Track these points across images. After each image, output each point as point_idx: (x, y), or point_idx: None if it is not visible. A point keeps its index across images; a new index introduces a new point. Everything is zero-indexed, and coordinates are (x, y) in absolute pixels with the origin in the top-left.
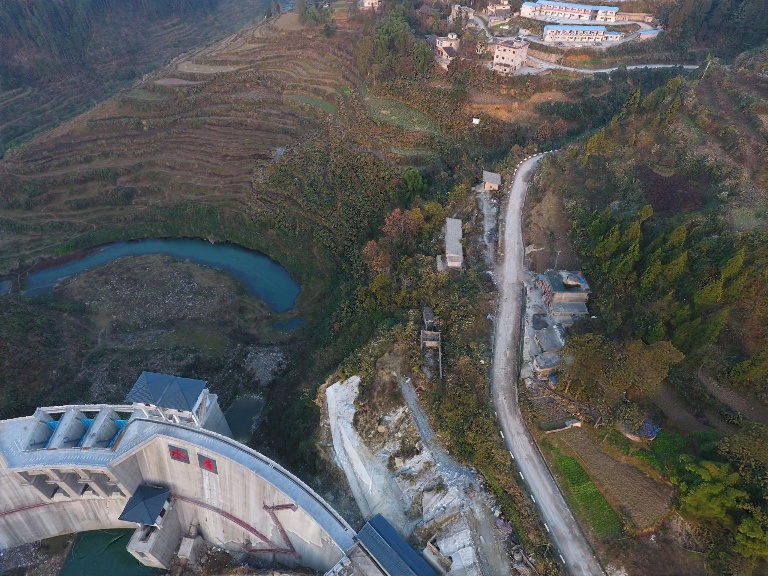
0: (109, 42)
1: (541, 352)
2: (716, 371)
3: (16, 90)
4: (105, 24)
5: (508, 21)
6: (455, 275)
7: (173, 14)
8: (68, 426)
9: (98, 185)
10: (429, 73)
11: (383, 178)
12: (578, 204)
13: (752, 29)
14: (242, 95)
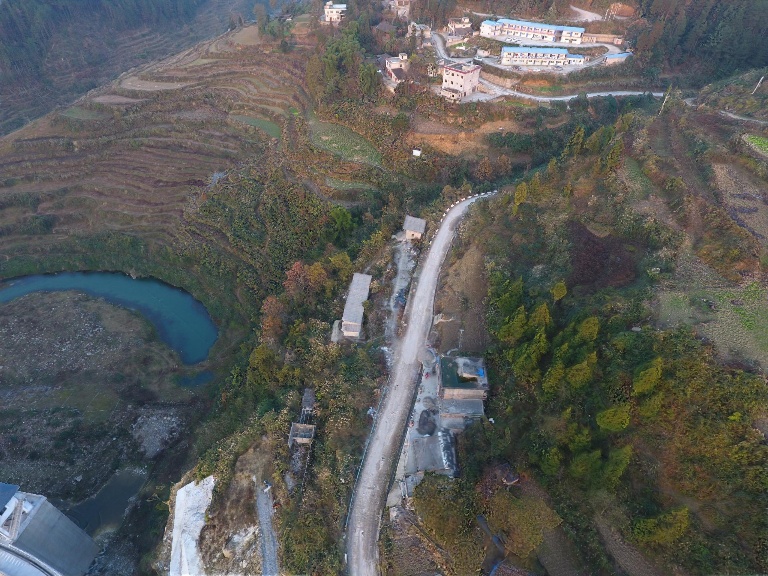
0: (70, 53)
1: (417, 469)
2: (619, 521)
3: None
4: (67, 34)
5: (467, 41)
6: (349, 348)
7: (145, 24)
8: None
9: (17, 211)
10: (376, 96)
11: (313, 214)
12: (498, 266)
13: (729, 54)
14: (185, 114)
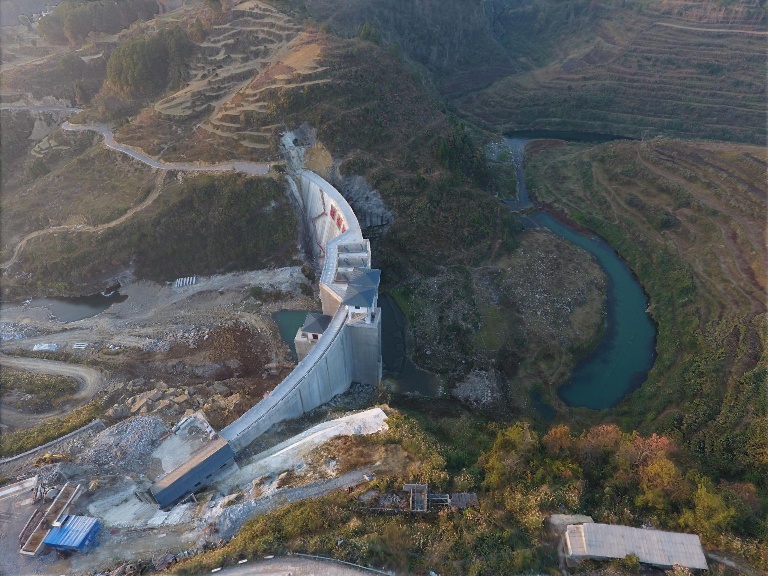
0: None
1: None
2: None
3: None
4: None
5: None
6: (544, 542)
7: None
8: (355, 257)
9: (666, 200)
10: None
11: None
12: None
13: None
14: None
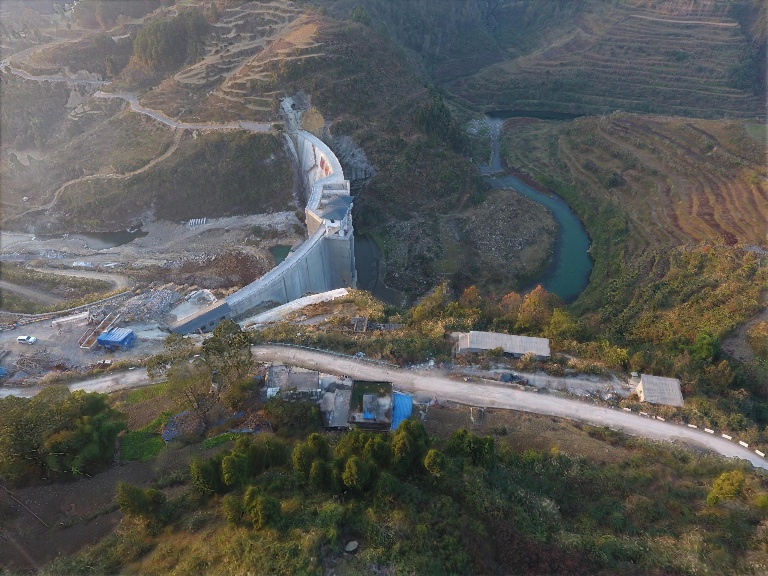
0: None
1: None
2: None
3: (735, 90)
4: None
5: None
6: (442, 345)
7: None
8: (336, 192)
9: (617, 164)
10: None
11: None
12: None
13: None
14: None
